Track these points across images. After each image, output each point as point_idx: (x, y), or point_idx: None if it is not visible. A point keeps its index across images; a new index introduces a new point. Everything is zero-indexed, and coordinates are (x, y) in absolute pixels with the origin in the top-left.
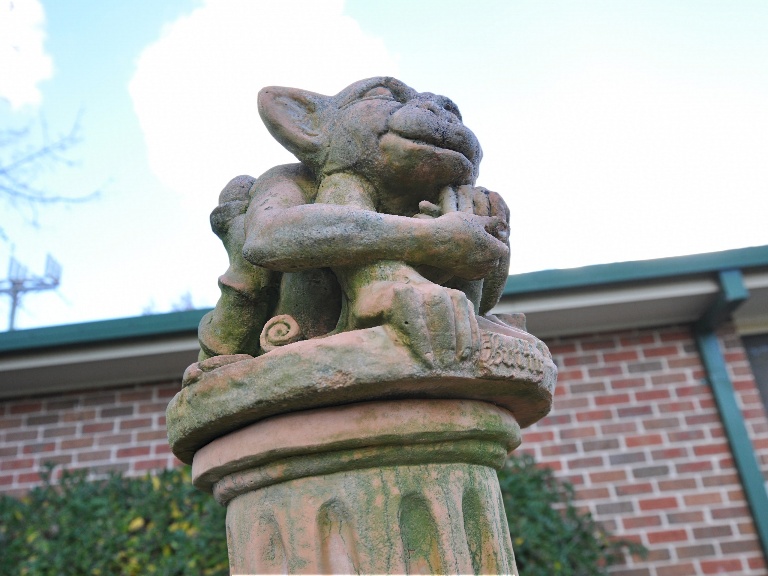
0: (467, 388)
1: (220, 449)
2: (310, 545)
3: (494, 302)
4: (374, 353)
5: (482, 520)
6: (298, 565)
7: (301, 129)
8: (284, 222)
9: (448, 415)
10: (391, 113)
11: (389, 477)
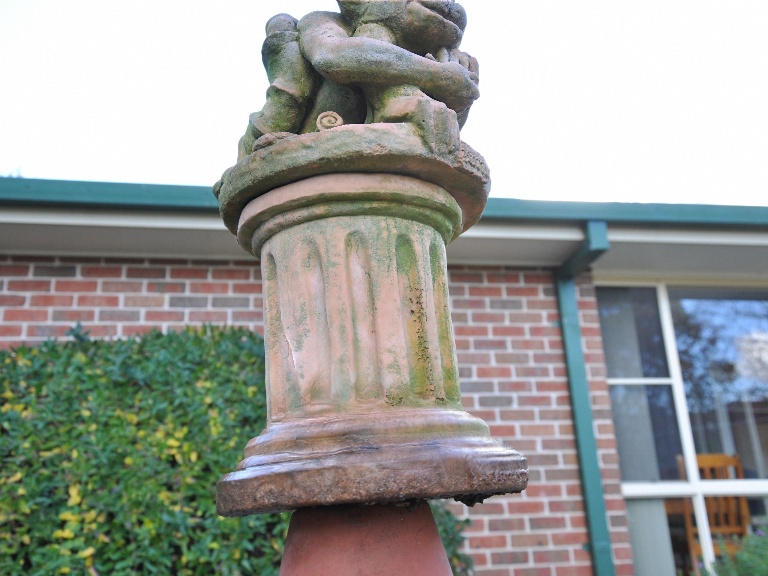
0: (444, 176)
1: (280, 193)
2: (340, 255)
3: None
4: (401, 137)
5: (437, 264)
6: (331, 266)
7: None
8: (349, 45)
9: (431, 190)
10: None
11: (391, 222)
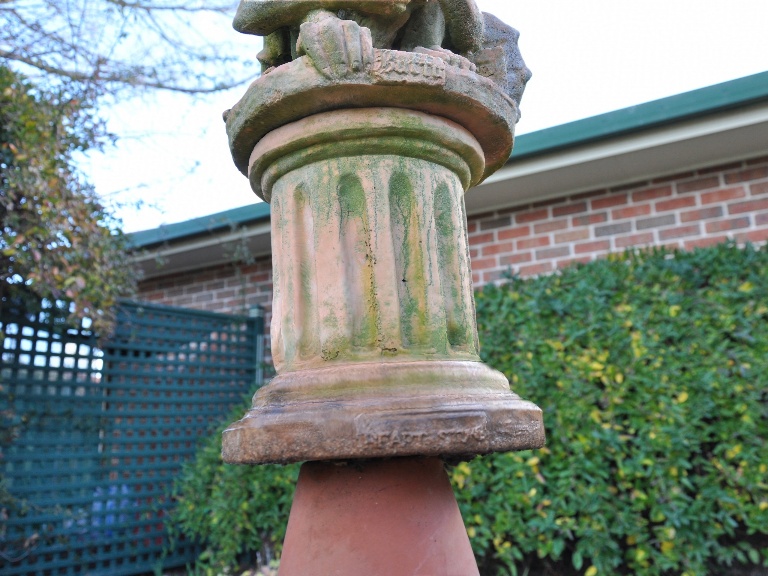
0: (379, 96)
1: None
2: (290, 211)
3: (471, 40)
4: (293, 74)
5: (412, 195)
6: (285, 224)
7: None
8: None
9: (366, 117)
10: None
11: (333, 165)
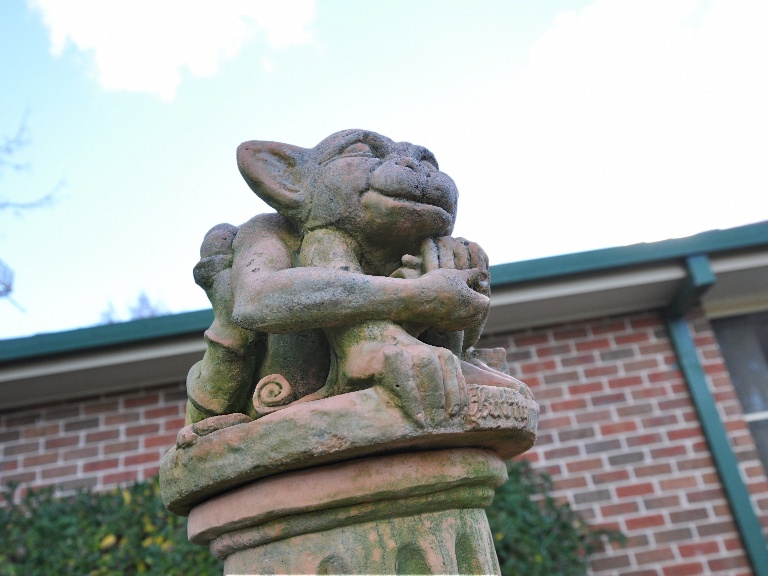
0: (456, 439)
1: (218, 510)
2: None
3: (475, 339)
4: (367, 416)
5: (474, 563)
6: None
7: (282, 185)
8: (273, 288)
9: (439, 467)
10: (371, 171)
11: (385, 530)
